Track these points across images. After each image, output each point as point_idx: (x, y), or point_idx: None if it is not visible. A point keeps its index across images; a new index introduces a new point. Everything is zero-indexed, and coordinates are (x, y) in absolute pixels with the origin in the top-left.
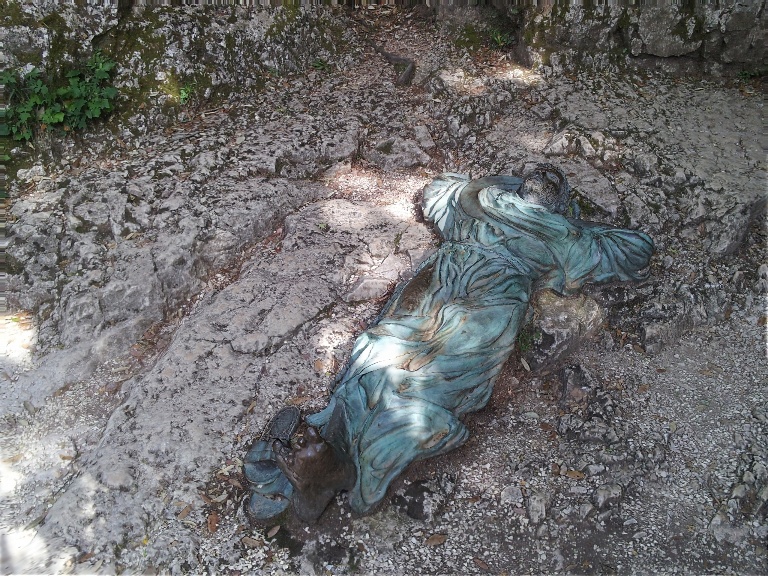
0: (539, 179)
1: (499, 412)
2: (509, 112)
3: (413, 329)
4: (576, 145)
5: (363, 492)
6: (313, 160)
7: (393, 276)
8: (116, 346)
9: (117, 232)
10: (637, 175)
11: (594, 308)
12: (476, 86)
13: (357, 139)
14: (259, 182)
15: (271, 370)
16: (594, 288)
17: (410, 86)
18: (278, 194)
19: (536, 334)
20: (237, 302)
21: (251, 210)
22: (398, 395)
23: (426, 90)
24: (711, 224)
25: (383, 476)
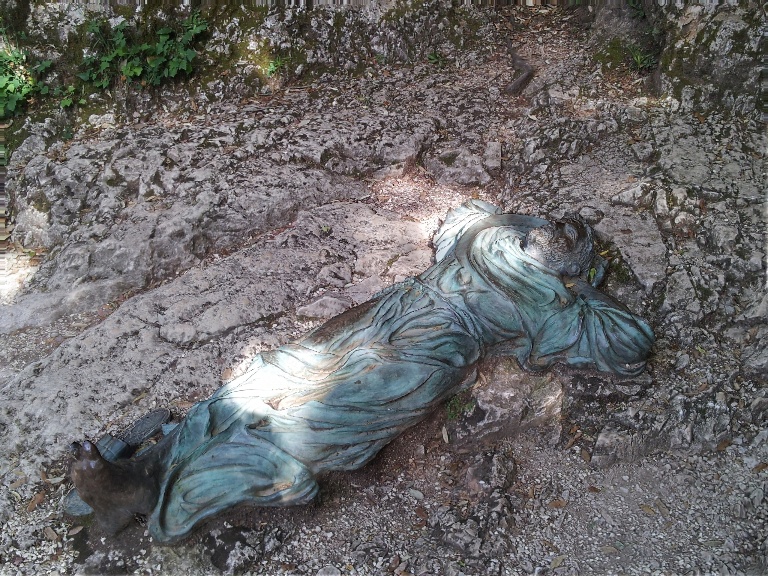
0: (549, 230)
1: (384, 479)
2: (606, 145)
3: (305, 364)
4: (652, 198)
5: (168, 521)
6: (365, 157)
7: (361, 299)
8: (87, 302)
9: (142, 192)
10: (707, 249)
11: (554, 393)
12: (586, 109)
13: (421, 144)
14: (293, 170)
15: (179, 366)
16: (566, 370)
17: (517, 96)
18: (305, 186)
19: (469, 405)
20: (190, 288)
21: (270, 197)
22: (247, 431)
23: (530, 103)
24: (764, 330)
25: (195, 511)
